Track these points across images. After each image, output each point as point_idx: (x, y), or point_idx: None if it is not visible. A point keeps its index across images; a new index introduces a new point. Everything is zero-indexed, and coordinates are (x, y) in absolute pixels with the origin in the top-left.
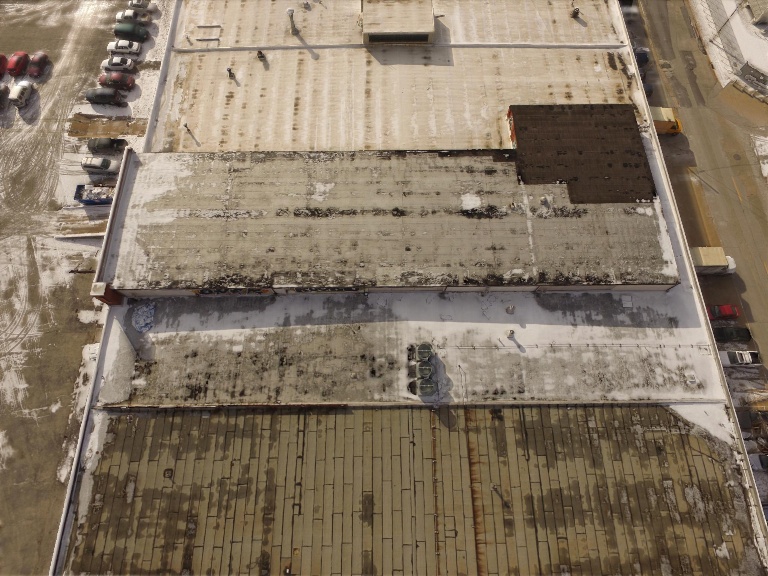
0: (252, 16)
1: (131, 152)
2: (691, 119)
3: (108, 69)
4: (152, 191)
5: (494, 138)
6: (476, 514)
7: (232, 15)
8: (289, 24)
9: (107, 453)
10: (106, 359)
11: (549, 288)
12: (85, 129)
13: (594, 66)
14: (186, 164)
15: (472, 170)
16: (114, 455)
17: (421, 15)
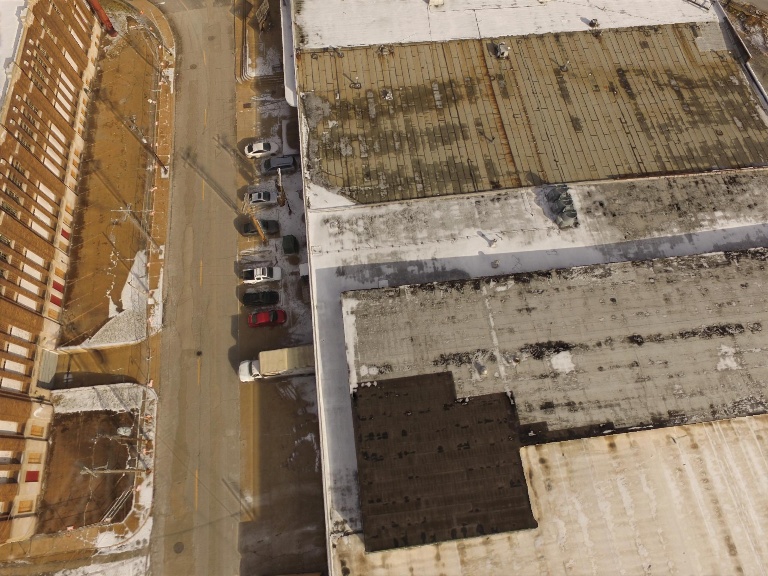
0: None
1: None
2: None
3: None
4: None
5: (541, 482)
6: (502, 127)
7: None
8: None
9: None
10: None
11: None
12: None
13: None
14: None
15: (569, 406)
16: (763, 140)
17: None
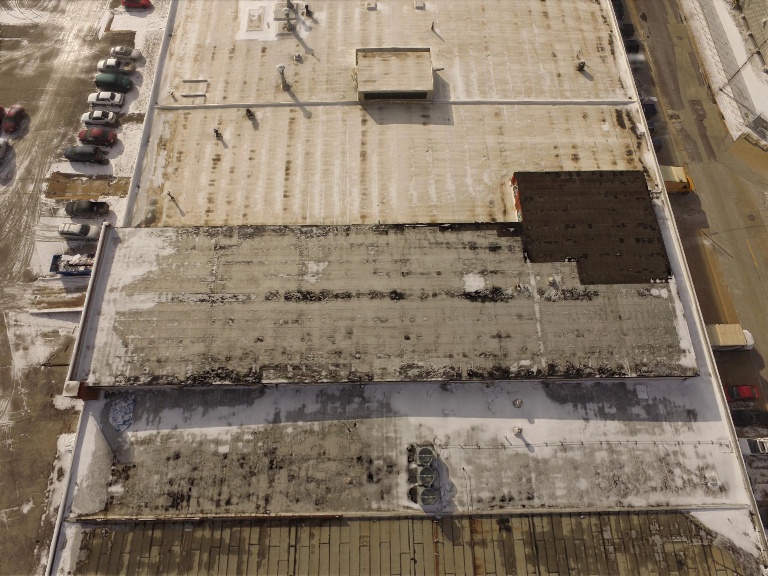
0: (241, 69)
1: (109, 228)
2: (702, 175)
3: (89, 123)
4: (132, 272)
5: (497, 206)
6: None
7: (219, 68)
8: (280, 78)
9: (80, 573)
10: (80, 462)
11: (559, 379)
12: (63, 189)
13: (602, 125)
14: (169, 240)
15: (475, 246)
16: (88, 575)
17: (419, 71)
